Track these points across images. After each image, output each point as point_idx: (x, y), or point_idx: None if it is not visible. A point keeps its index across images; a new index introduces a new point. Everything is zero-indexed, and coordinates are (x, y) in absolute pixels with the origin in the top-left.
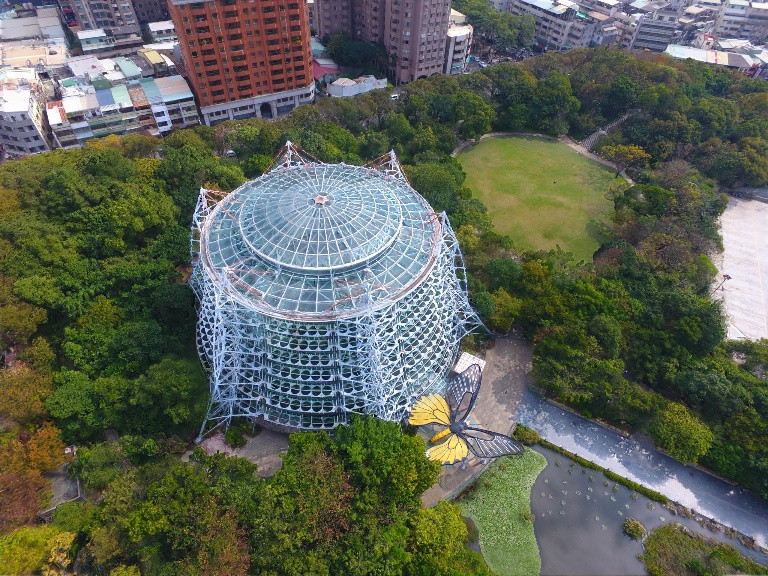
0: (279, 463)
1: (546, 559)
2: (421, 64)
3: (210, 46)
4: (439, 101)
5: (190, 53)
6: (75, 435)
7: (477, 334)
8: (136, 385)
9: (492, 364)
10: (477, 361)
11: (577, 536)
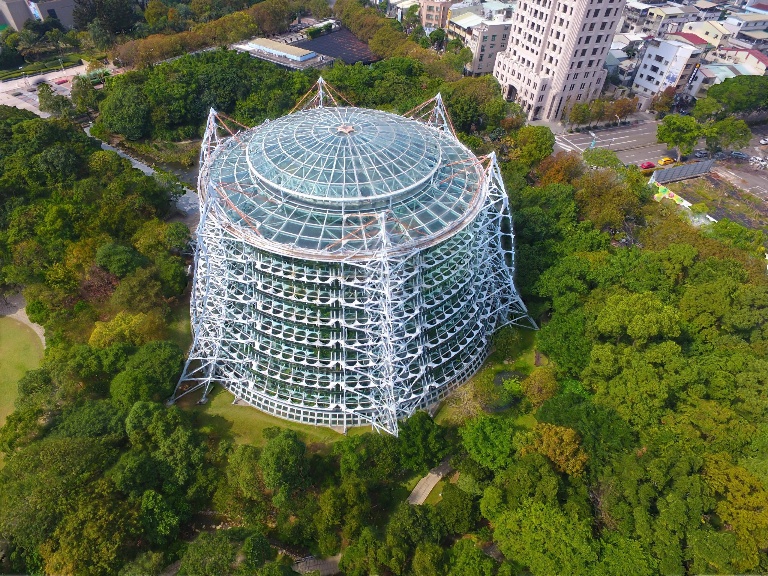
0: None
1: None
2: None
3: None
4: None
5: None
6: None
7: None
8: None
9: None
10: None
11: None
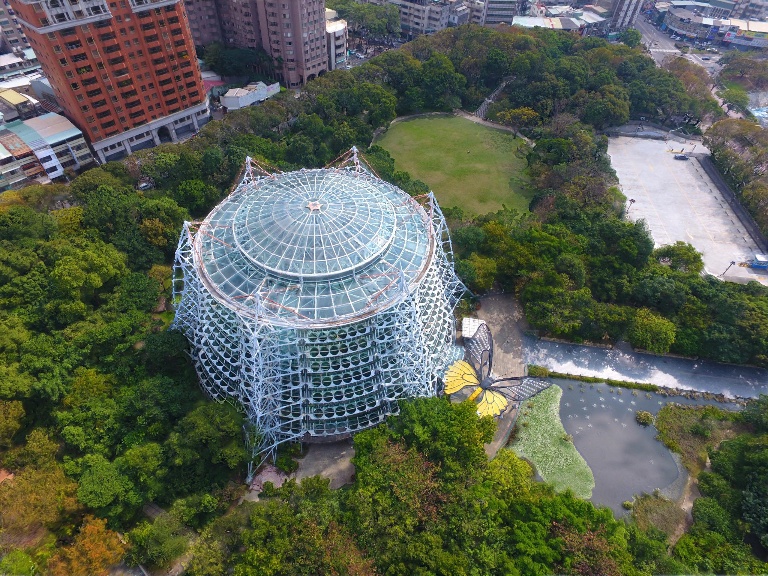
0: (339, 472)
1: (594, 466)
2: (308, 63)
3: (91, 74)
4: (343, 96)
5: (69, 85)
6: (117, 521)
7: (465, 300)
8: (174, 445)
9: (486, 322)
10: (478, 322)
11: (608, 439)
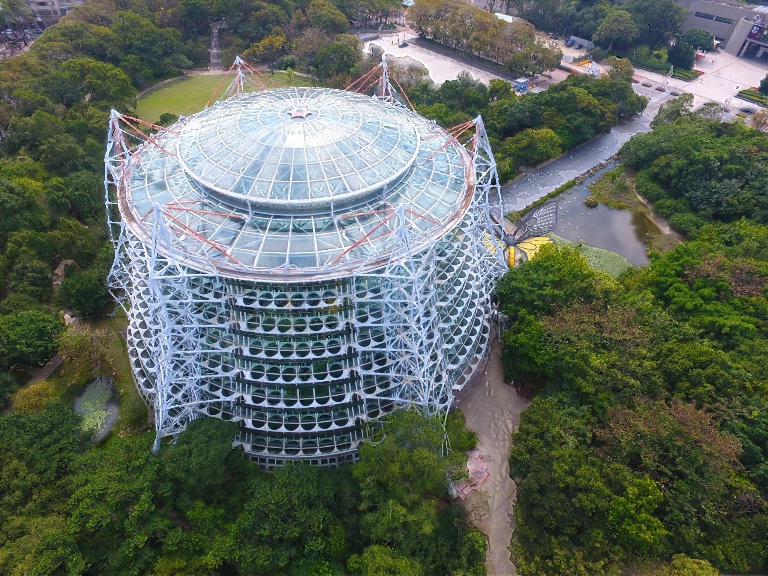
0: (505, 401)
1: (610, 249)
2: None
3: None
4: (52, 83)
5: None
6: None
7: None
8: (397, 519)
9: None
10: None
11: (595, 228)
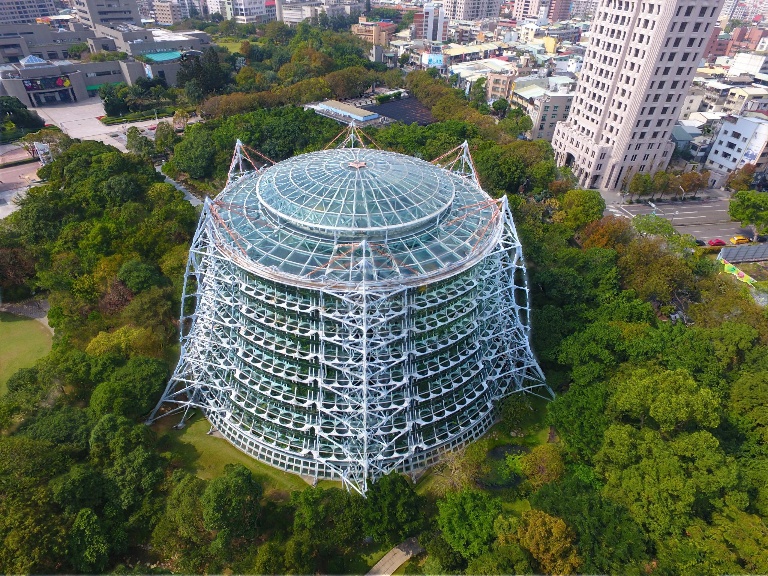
0: None
1: None
2: None
3: None
4: None
5: None
6: None
7: None
8: None
9: None
10: None
11: None
